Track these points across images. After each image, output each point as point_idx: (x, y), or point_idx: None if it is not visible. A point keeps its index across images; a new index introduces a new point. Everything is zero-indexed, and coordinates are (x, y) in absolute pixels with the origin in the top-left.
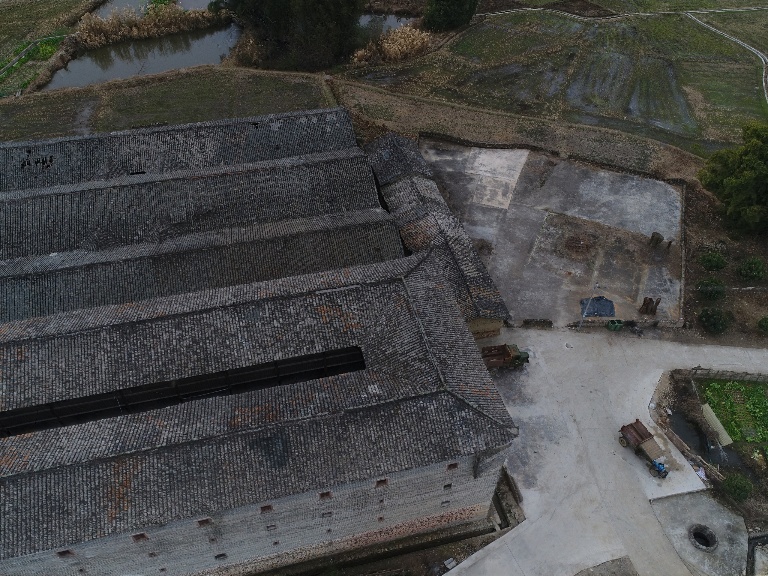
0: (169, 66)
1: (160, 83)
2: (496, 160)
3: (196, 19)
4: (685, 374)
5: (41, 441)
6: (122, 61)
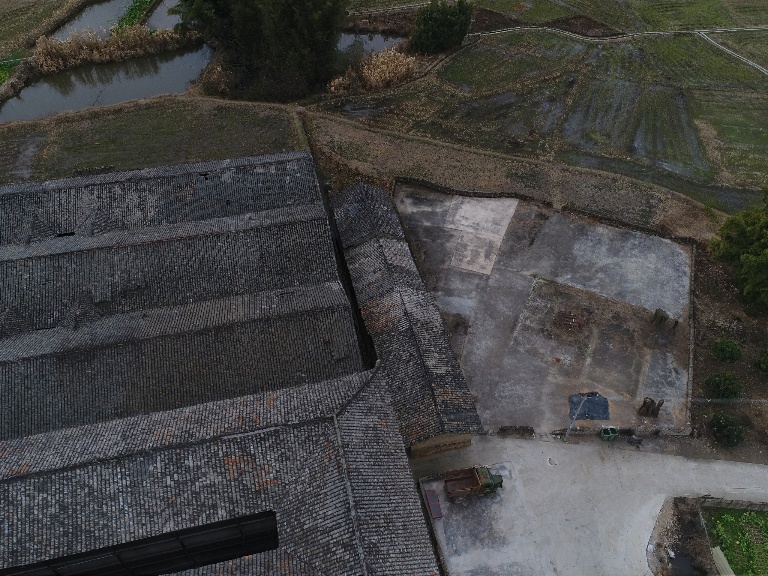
0: (129, 95)
1: (116, 116)
2: (480, 212)
3: (164, 40)
4: (692, 504)
5: None
6: (84, 86)
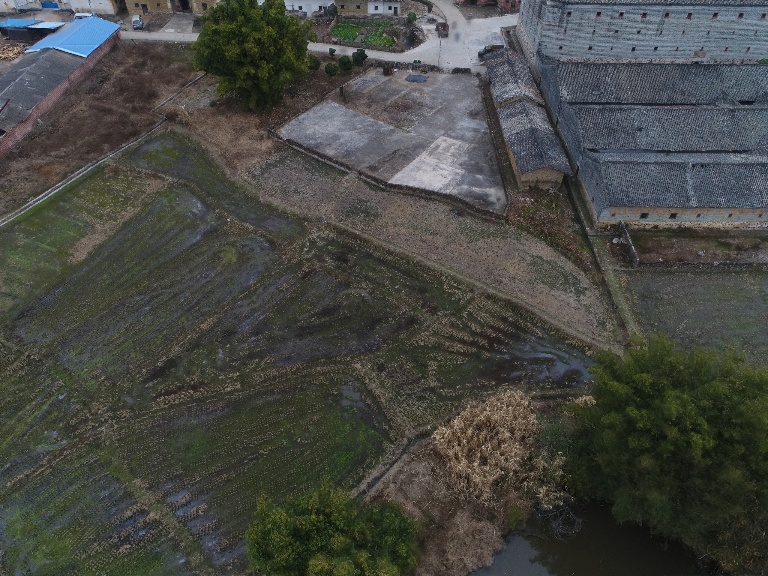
0: None
1: None
2: (427, 179)
3: None
4: None
5: None
6: None
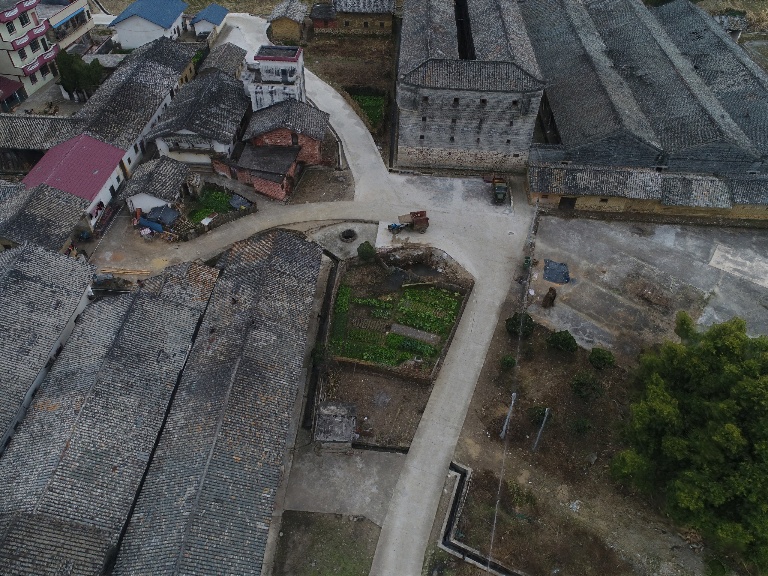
0: None
1: None
2: None
3: None
4: (466, 281)
5: (447, 3)
6: None
